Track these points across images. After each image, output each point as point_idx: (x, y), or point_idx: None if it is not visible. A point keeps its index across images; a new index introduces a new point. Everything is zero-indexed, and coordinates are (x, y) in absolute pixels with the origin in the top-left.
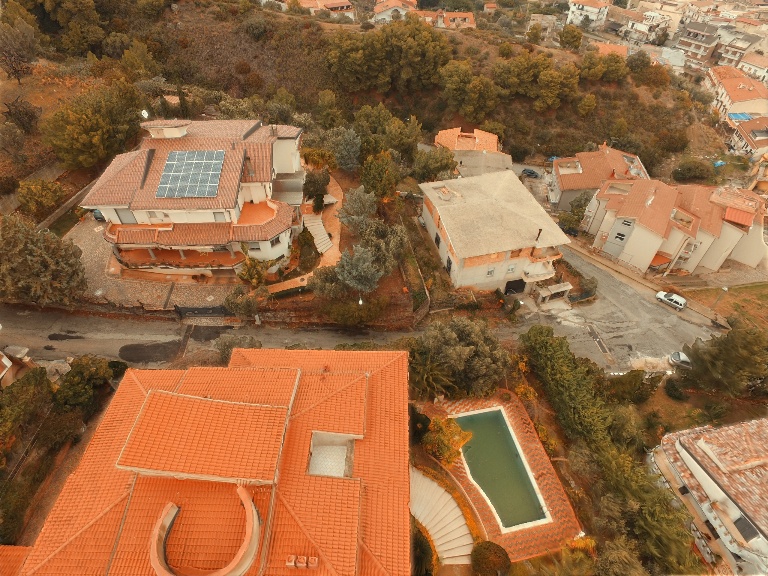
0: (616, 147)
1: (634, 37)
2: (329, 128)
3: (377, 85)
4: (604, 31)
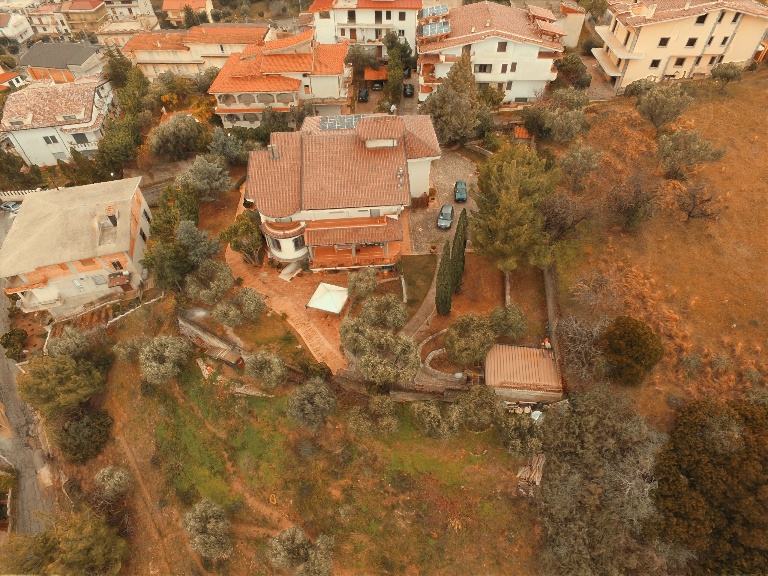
0: None
1: None
2: None
3: None
4: None
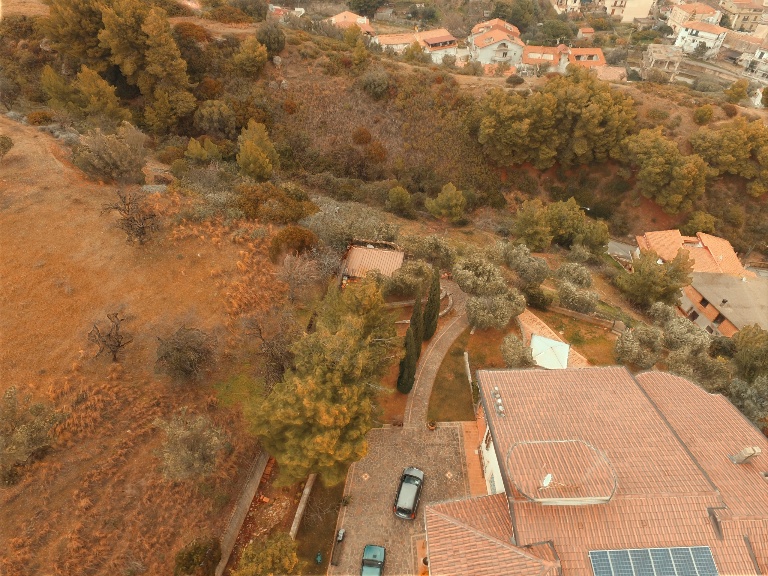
0: None
1: (763, 69)
2: (533, 250)
3: (535, 159)
4: (722, 60)
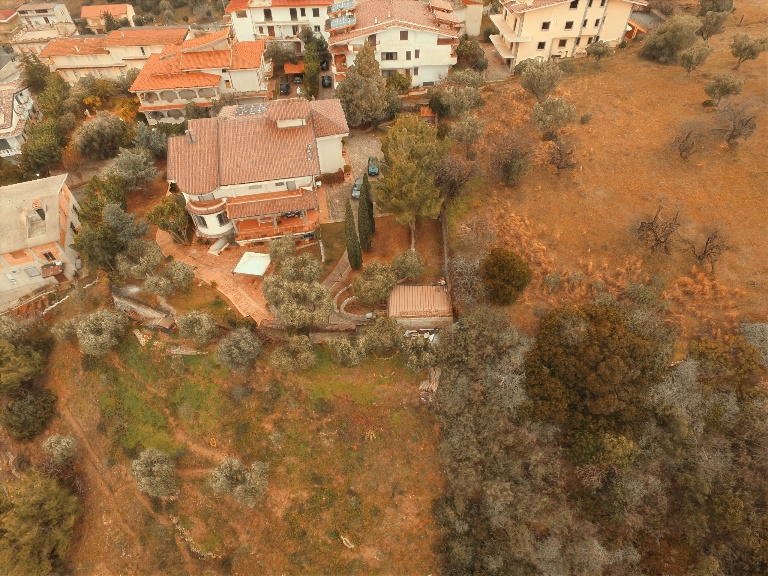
0: None
1: None
2: None
3: None
4: None
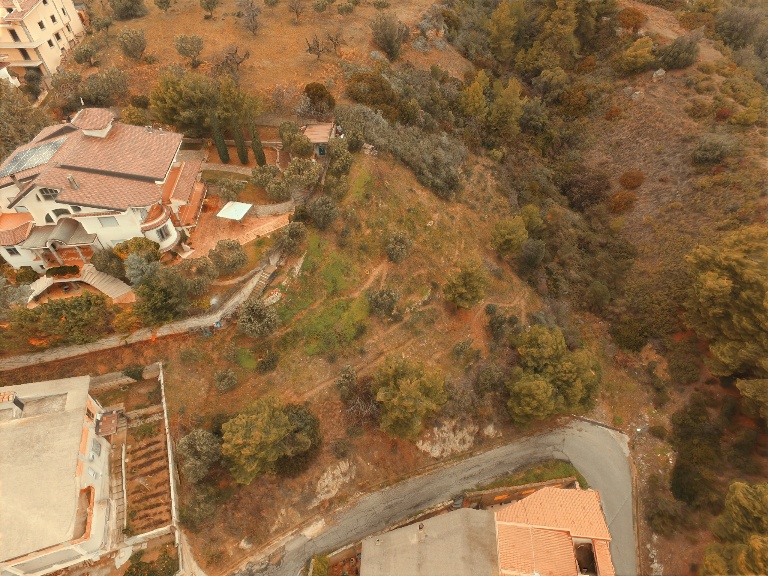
0: None
1: None
2: None
3: None
4: None
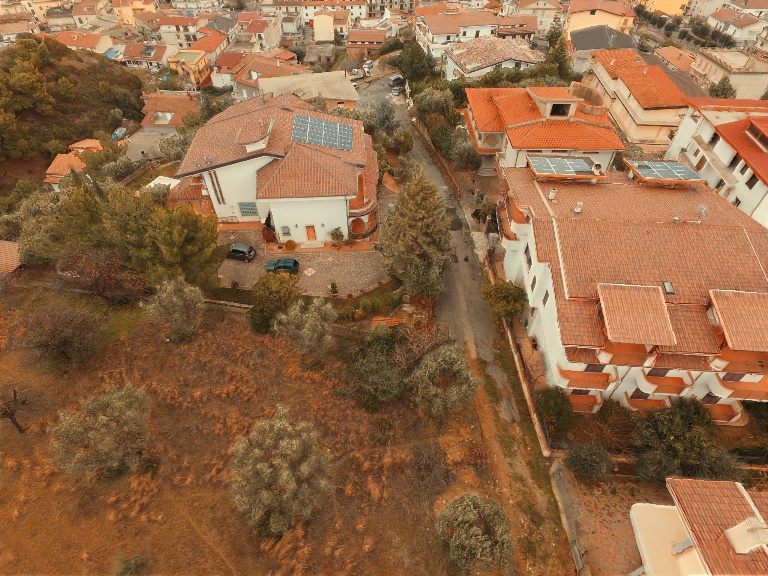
0: (121, 105)
1: None
2: None
3: None
4: None
